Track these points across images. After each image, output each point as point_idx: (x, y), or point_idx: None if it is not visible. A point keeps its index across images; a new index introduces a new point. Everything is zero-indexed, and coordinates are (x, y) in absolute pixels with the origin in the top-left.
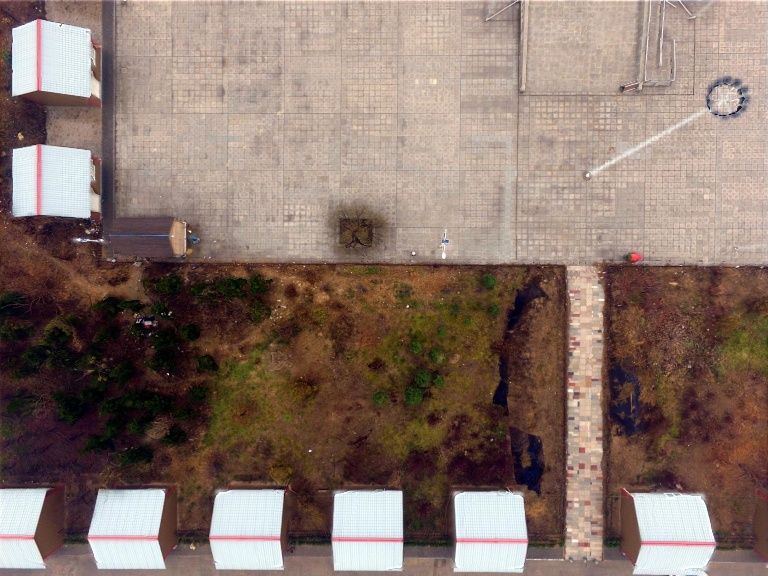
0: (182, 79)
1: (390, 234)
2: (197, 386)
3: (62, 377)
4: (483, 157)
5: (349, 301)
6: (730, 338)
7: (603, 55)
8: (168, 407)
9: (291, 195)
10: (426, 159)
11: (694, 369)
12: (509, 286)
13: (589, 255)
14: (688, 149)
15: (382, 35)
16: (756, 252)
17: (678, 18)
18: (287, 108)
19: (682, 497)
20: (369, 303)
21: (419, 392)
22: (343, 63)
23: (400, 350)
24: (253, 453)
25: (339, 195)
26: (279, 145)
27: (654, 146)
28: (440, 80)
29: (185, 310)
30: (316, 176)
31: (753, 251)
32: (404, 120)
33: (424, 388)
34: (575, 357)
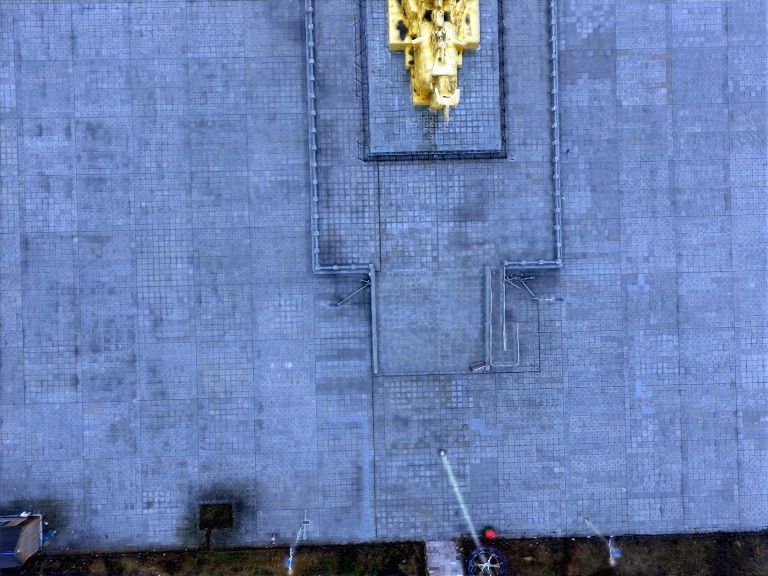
0: (34, 370)
1: (250, 517)
2: None
3: None
4: (340, 438)
5: None
6: None
7: (451, 338)
8: None
9: (149, 482)
10: (284, 441)
11: None
12: (369, 566)
13: (447, 530)
14: (537, 424)
15: (236, 321)
16: (606, 522)
17: (522, 299)
18: (143, 395)
19: None
20: None
21: None
22: (198, 349)
23: None
24: None
25: (198, 480)
26: (136, 432)
27: (505, 422)
28: (295, 363)
29: None
30: (174, 462)
31: (603, 521)
32: (261, 403)
33: None
34: None
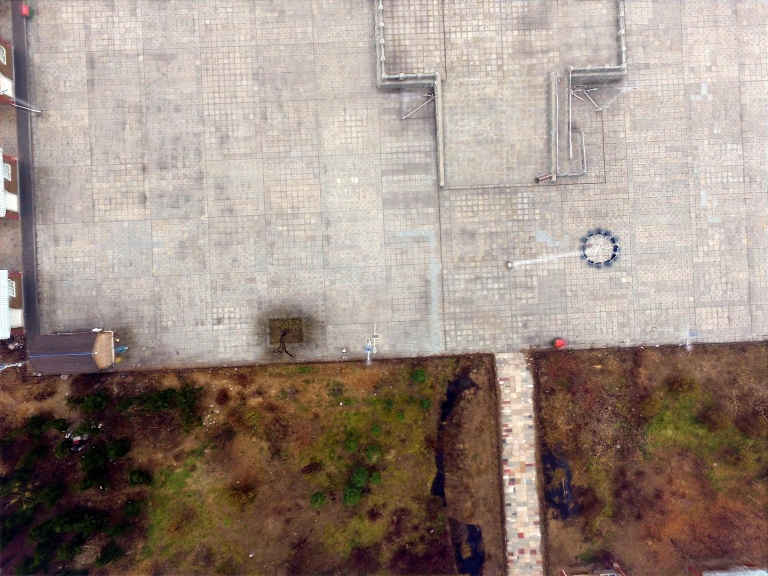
0: (102, 188)
1: (320, 332)
2: (131, 498)
3: None
4: (408, 251)
5: (282, 402)
6: (654, 416)
7: (517, 149)
8: (100, 526)
9: (219, 298)
10: (352, 256)
11: (622, 449)
12: (440, 377)
13: (516, 342)
14: None
15: (302, 136)
16: (674, 331)
17: (586, 110)
18: (211, 212)
19: None
20: (302, 403)
21: (355, 492)
22: (265, 165)
23: (336, 448)
24: (192, 562)
25: (267, 296)
26: (204, 249)
27: (571, 233)
28: (361, 178)
29: (115, 422)
30: (243, 278)
31: (671, 330)
32: (328, 219)
33: (361, 486)
34: (508, 444)
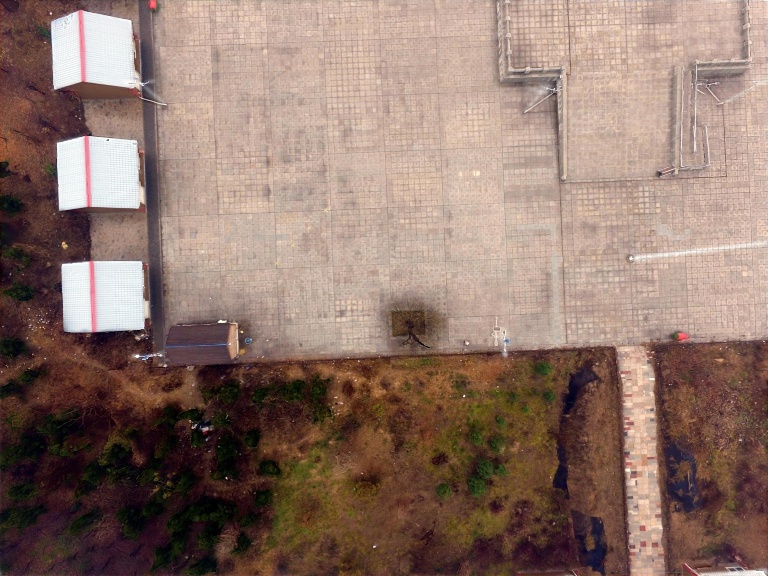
0: (227, 180)
1: (442, 324)
2: (257, 489)
3: (122, 494)
4: (529, 245)
5: (406, 394)
6: None
7: (639, 142)
8: (231, 516)
9: (342, 290)
10: (474, 249)
11: (745, 442)
12: (562, 370)
13: (637, 335)
14: (724, 229)
15: (424, 130)
16: None
17: (707, 104)
18: (334, 205)
19: (745, 573)
20: (426, 395)
21: (483, 484)
22: (387, 158)
23: (459, 440)
24: (317, 553)
25: (390, 288)
26: (327, 242)
27: (692, 227)
28: (483, 171)
29: (241, 413)
30: (366, 271)
31: None
32: (450, 212)
33: (486, 478)
34: (630, 437)
